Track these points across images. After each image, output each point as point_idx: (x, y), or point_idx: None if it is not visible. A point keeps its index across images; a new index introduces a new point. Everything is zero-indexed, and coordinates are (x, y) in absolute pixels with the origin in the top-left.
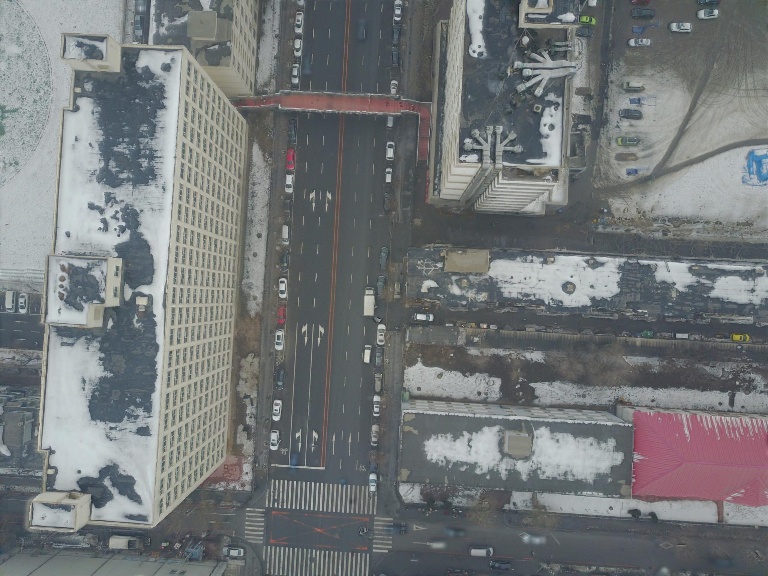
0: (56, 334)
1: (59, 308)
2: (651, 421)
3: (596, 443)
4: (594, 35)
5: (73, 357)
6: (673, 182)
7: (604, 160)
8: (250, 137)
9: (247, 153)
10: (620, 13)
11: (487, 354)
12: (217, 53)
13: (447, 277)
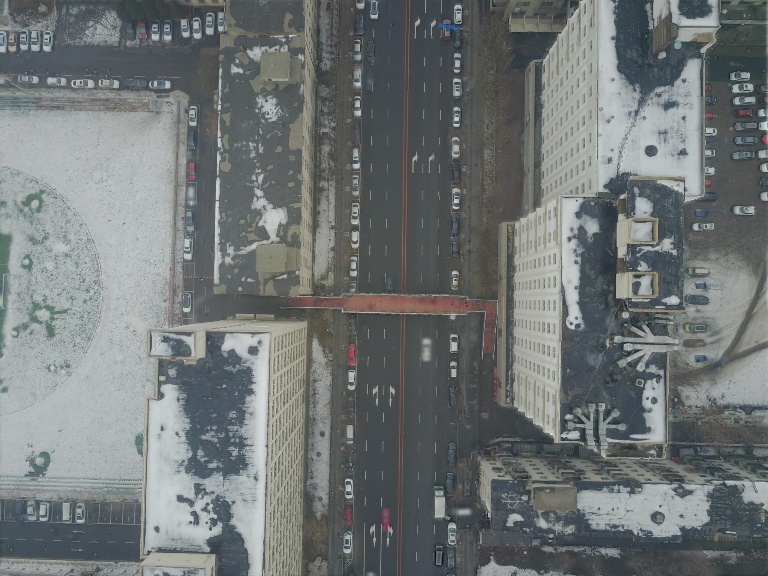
0: None
1: None
2: None
3: None
4: None
5: None
6: (743, 368)
7: None
8: (309, 333)
9: (307, 349)
10: None
11: (561, 550)
12: (286, 283)
13: (533, 510)
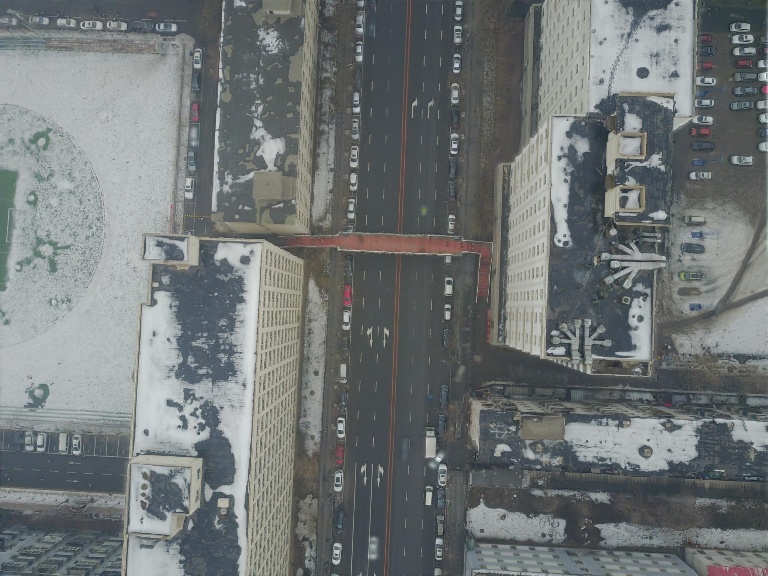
0: (135, 536)
1: (141, 518)
2: None
3: None
4: None
5: (153, 560)
6: (737, 317)
7: (666, 295)
8: (306, 273)
9: (303, 289)
10: (680, 145)
11: (551, 495)
12: (282, 211)
13: (521, 441)
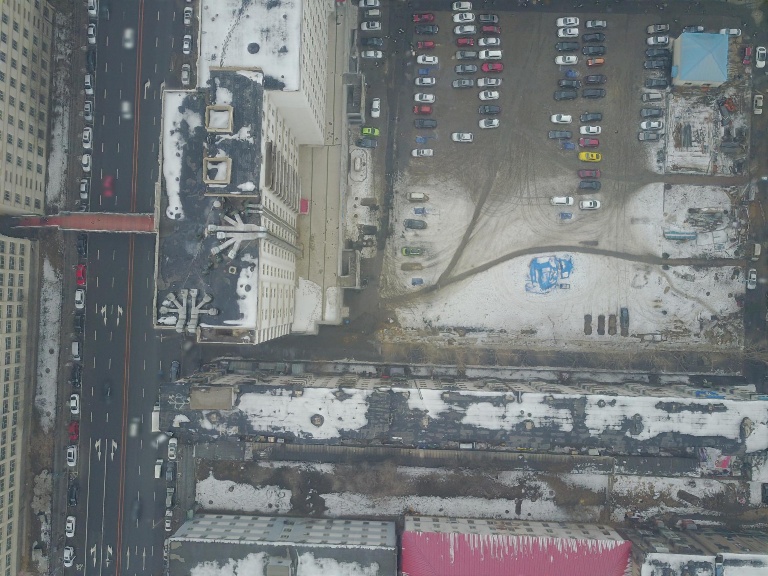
0: None
1: None
2: (419, 541)
3: (359, 567)
4: (378, 146)
5: None
6: (458, 291)
7: (390, 270)
8: (41, 253)
9: (38, 269)
10: (404, 123)
11: (278, 466)
12: None
13: (198, 411)
